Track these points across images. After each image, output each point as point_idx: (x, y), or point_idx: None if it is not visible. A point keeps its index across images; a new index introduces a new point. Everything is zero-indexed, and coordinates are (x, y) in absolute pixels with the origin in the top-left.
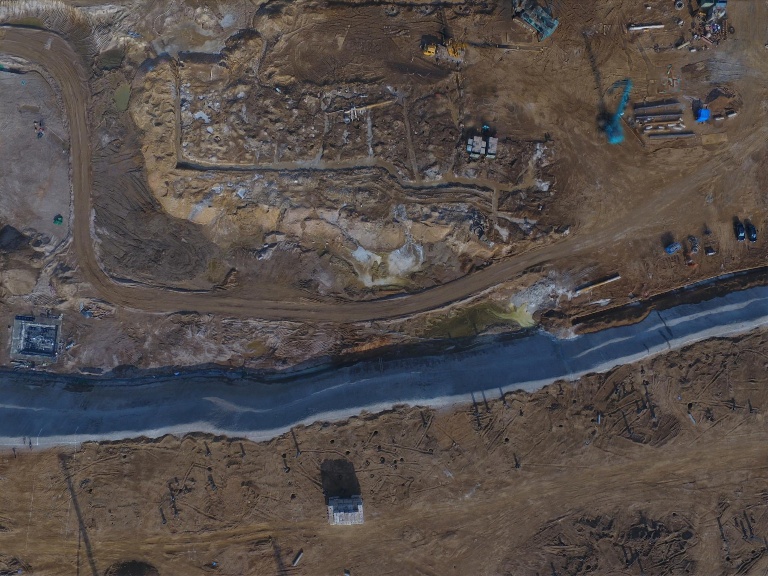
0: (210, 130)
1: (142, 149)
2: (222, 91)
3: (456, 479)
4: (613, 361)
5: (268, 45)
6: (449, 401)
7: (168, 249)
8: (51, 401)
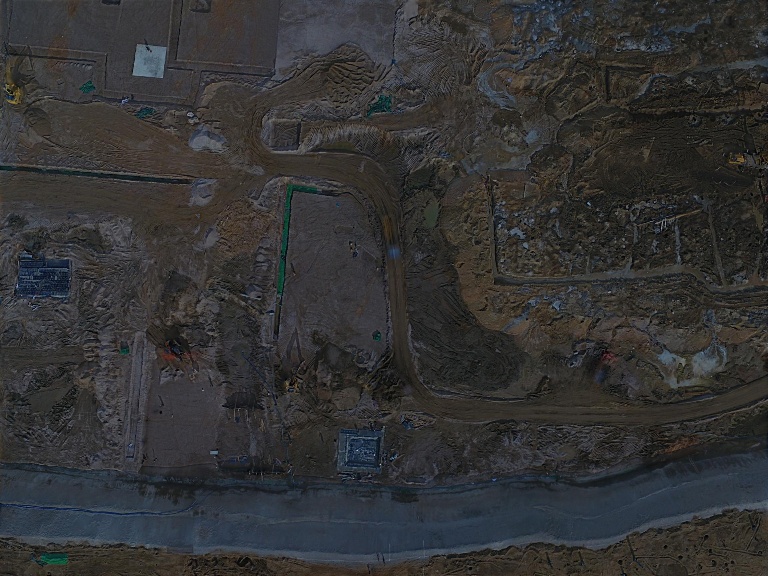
0: (526, 246)
1: (456, 265)
2: (535, 207)
3: None
4: None
5: (576, 160)
6: None
7: (484, 360)
8: (387, 514)
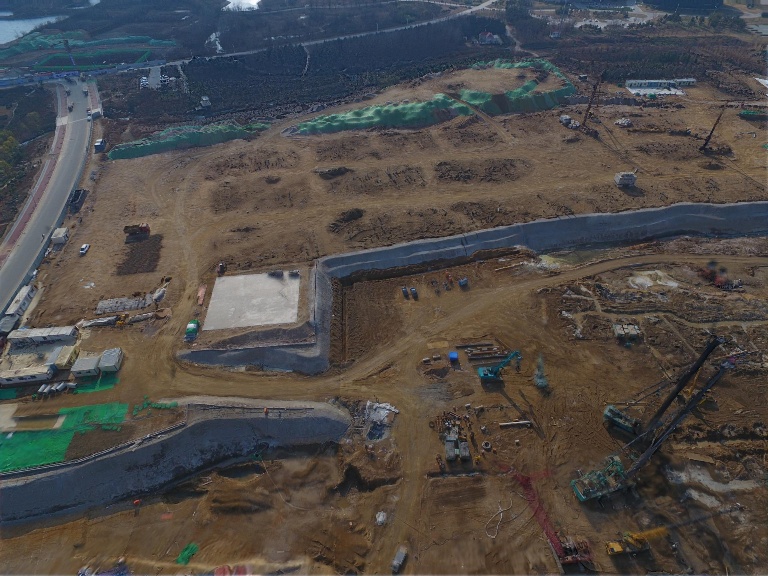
0: None
1: None
2: None
3: (570, 192)
4: (497, 229)
5: None
6: (588, 215)
7: None
8: None
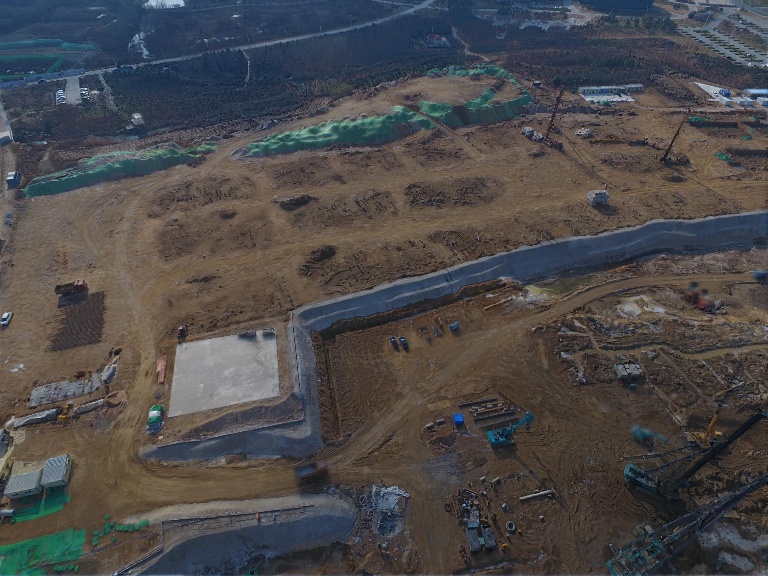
0: None
1: None
2: None
3: (546, 213)
4: (480, 261)
5: None
6: (569, 239)
7: None
8: None
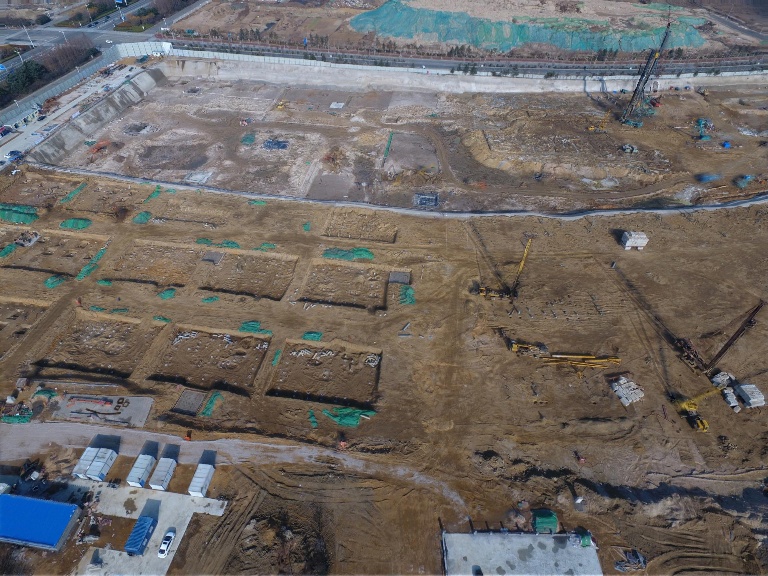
0: None
1: (470, 151)
2: None
3: (691, 239)
4: (748, 203)
5: None
6: (667, 212)
7: (489, 175)
8: None
